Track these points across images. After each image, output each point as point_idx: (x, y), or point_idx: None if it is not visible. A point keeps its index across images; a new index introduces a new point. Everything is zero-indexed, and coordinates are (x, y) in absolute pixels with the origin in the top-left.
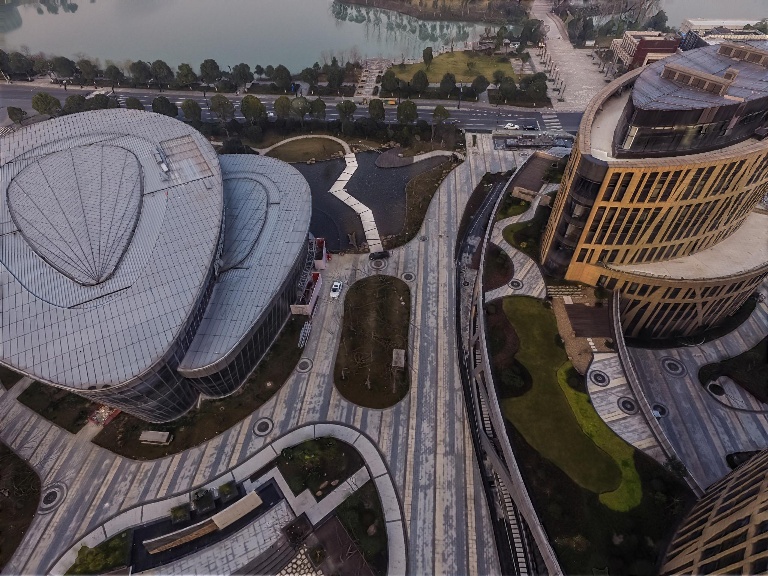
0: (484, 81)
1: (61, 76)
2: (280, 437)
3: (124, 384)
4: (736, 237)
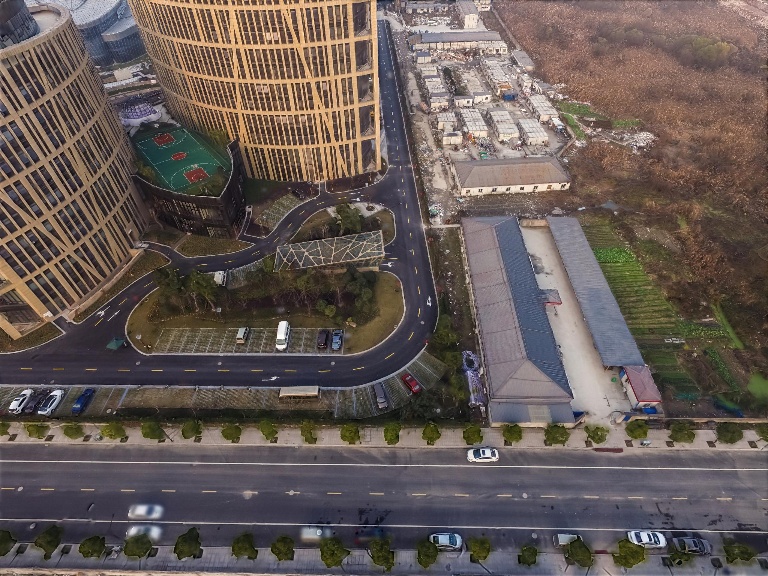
0: None
1: None
2: None
3: (81, 24)
4: None
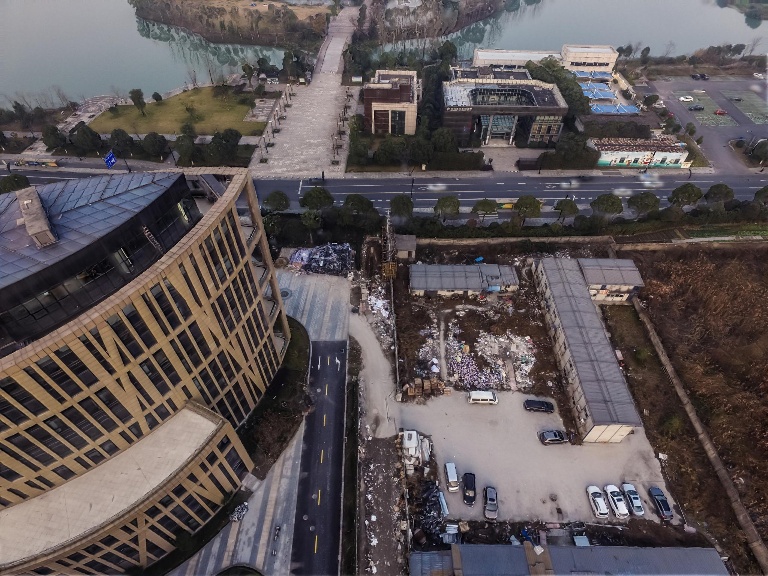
0: (154, 140)
1: None
2: None
3: None
4: (106, 468)
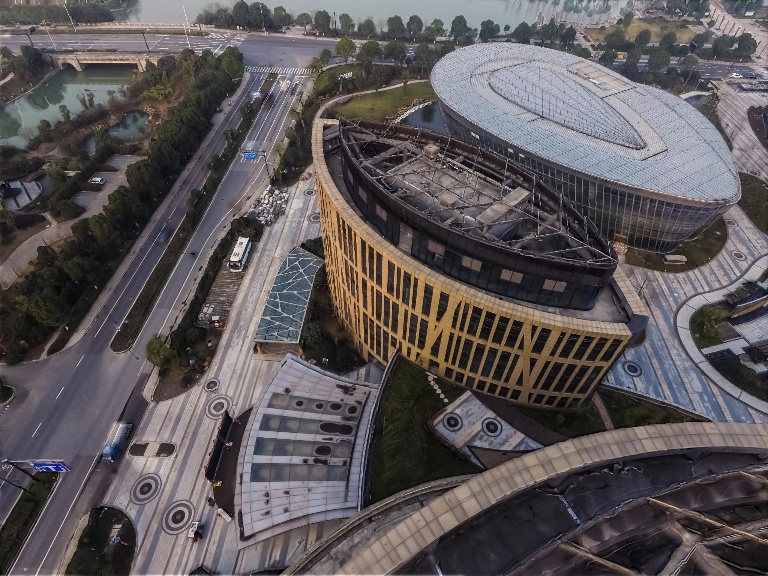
0: (703, 39)
1: (320, 28)
2: (756, 261)
3: None
4: None
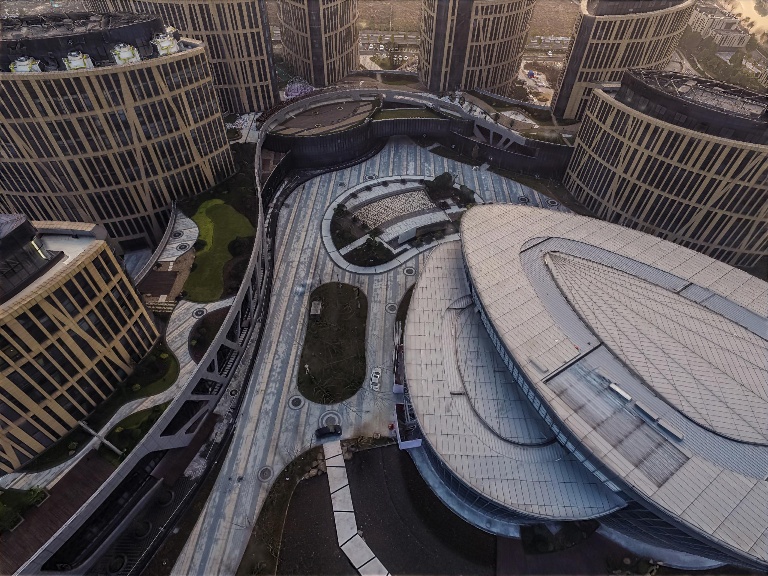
0: None
1: None
2: (397, 267)
3: None
4: None
